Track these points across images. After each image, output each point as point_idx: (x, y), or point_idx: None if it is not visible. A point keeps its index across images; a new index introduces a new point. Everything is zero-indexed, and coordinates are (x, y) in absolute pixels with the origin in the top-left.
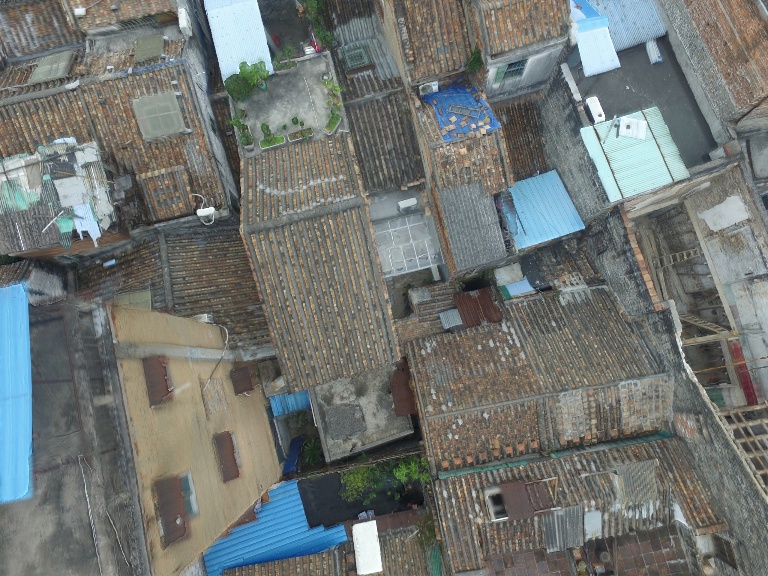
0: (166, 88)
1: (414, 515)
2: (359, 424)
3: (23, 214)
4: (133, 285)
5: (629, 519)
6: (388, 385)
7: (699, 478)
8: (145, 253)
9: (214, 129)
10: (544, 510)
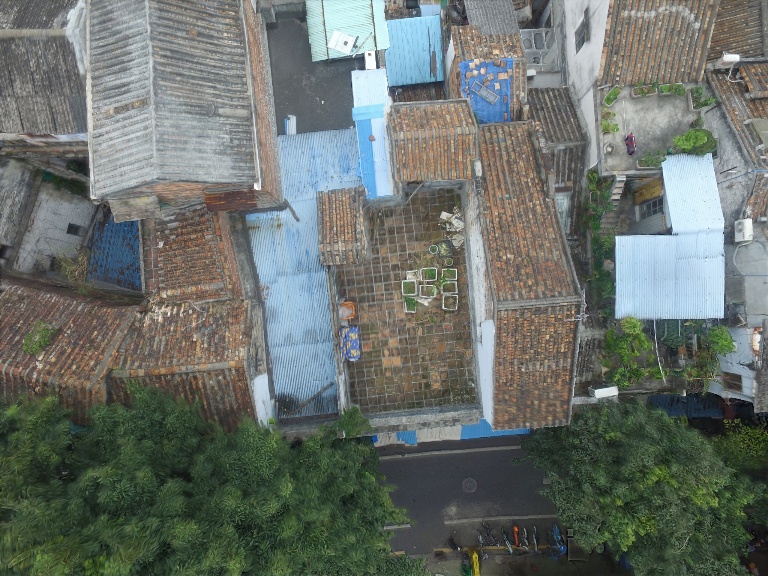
0: None
1: None
2: None
3: None
4: None
5: None
6: None
7: None
8: None
9: (711, 149)
10: None
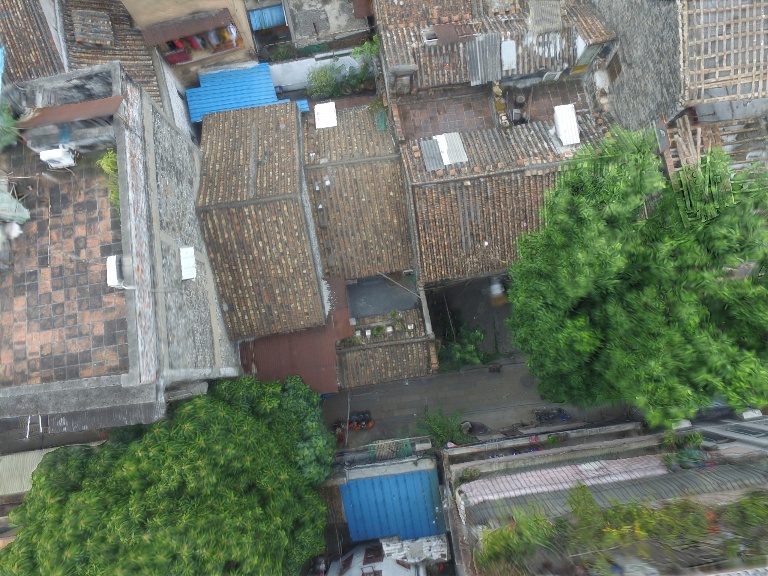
0: None
1: (367, 99)
2: (324, 24)
3: None
4: None
5: (540, 56)
6: None
7: (598, 18)
8: None
9: None
10: (467, 35)
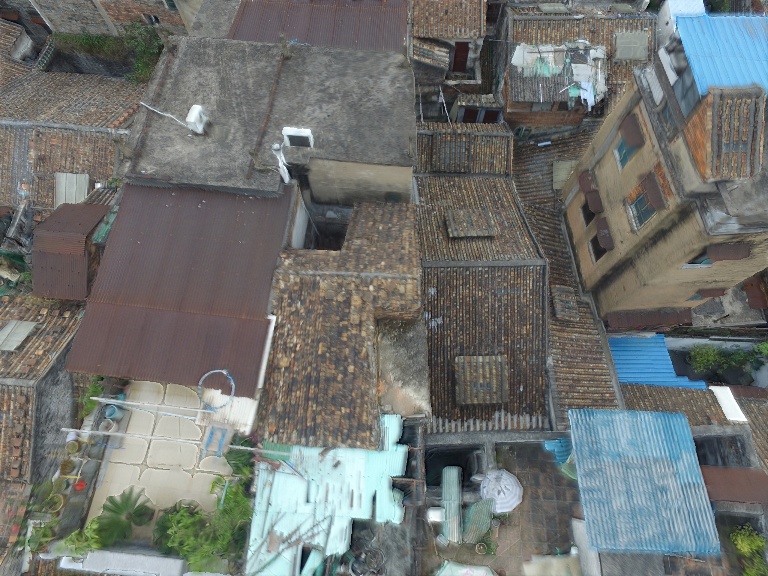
0: (639, 32)
1: (763, 391)
2: (718, 307)
3: (546, 80)
4: (569, 158)
5: None
6: (742, 284)
7: None
8: (584, 138)
9: None
10: None
